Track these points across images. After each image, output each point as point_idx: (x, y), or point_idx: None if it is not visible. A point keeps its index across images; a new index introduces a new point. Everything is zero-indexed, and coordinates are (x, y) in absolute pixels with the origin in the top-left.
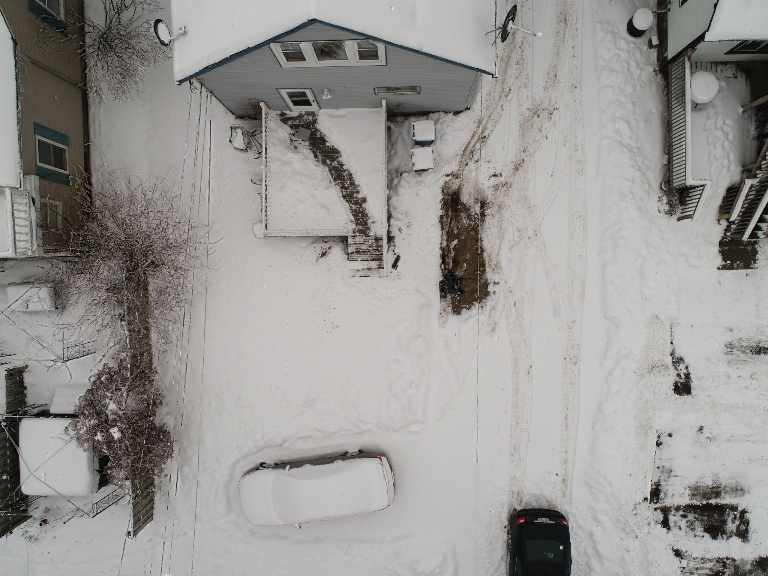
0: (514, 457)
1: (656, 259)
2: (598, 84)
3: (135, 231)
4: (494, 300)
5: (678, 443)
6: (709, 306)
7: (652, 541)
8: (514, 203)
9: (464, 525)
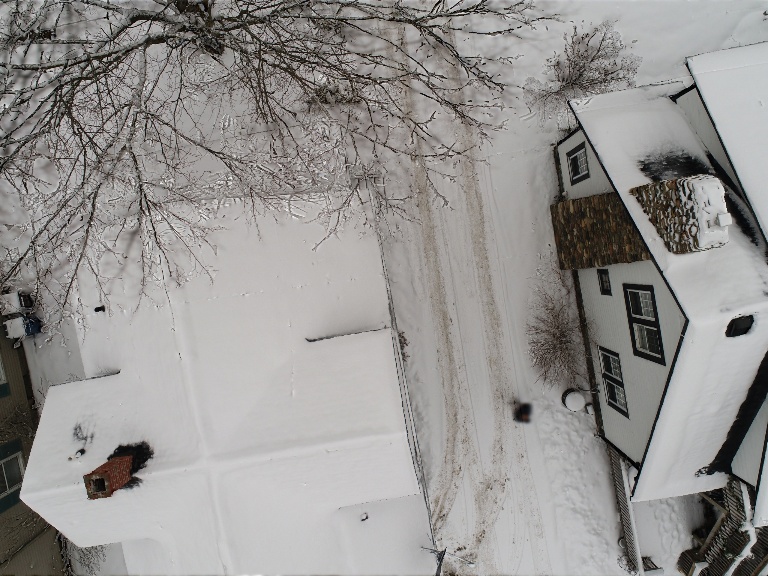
0: None
1: None
2: (543, 455)
3: None
4: None
5: None
6: None
7: None
8: (482, 573)
9: None
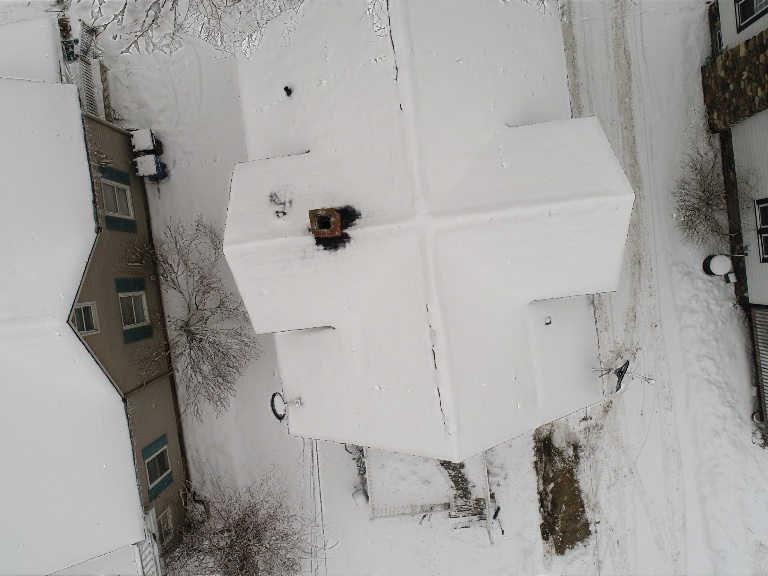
0: None
1: (754, 488)
2: (679, 323)
3: (245, 526)
4: None
5: None
6: None
7: None
8: (607, 445)
9: None
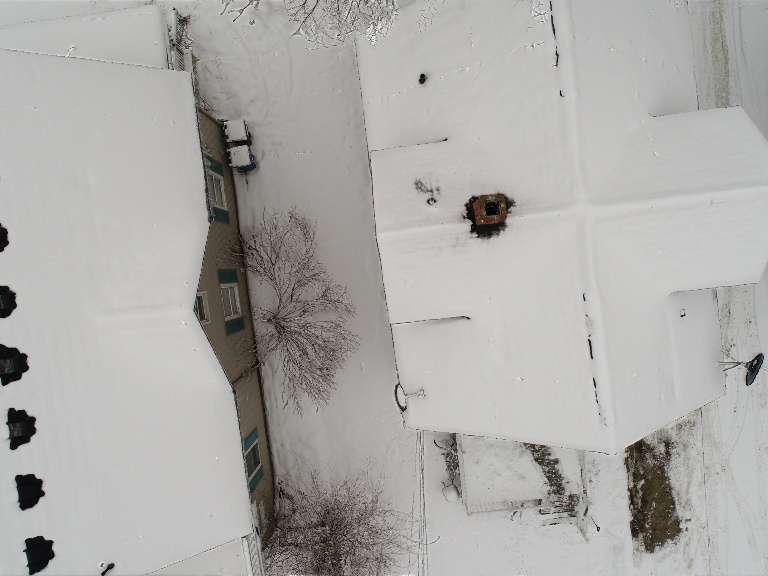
0: None
1: None
2: None
3: (338, 521)
4: (687, 536)
5: None
6: None
7: None
8: (699, 441)
9: None
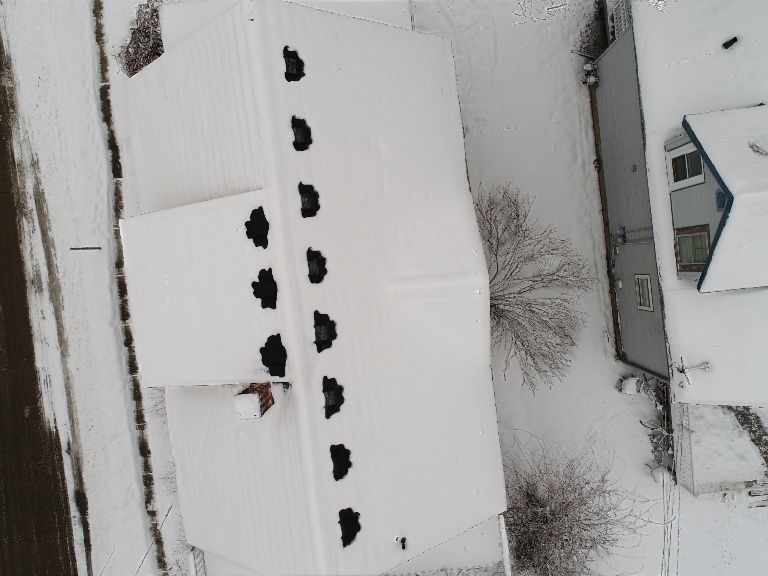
0: None
1: None
2: None
3: (558, 501)
4: None
5: None
6: None
7: None
8: None
9: None
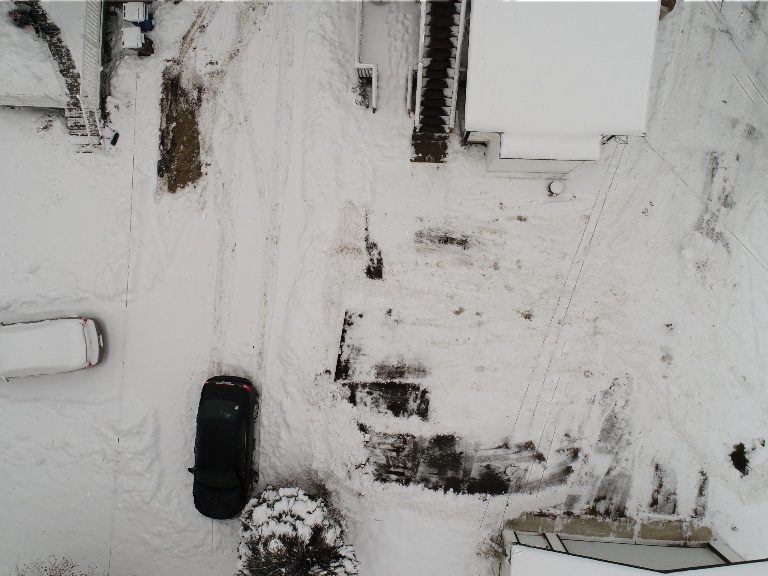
0: (217, 329)
1: (352, 148)
2: None
3: None
4: (206, 180)
5: (368, 324)
6: (402, 196)
7: (335, 413)
8: (227, 90)
9: (167, 391)
